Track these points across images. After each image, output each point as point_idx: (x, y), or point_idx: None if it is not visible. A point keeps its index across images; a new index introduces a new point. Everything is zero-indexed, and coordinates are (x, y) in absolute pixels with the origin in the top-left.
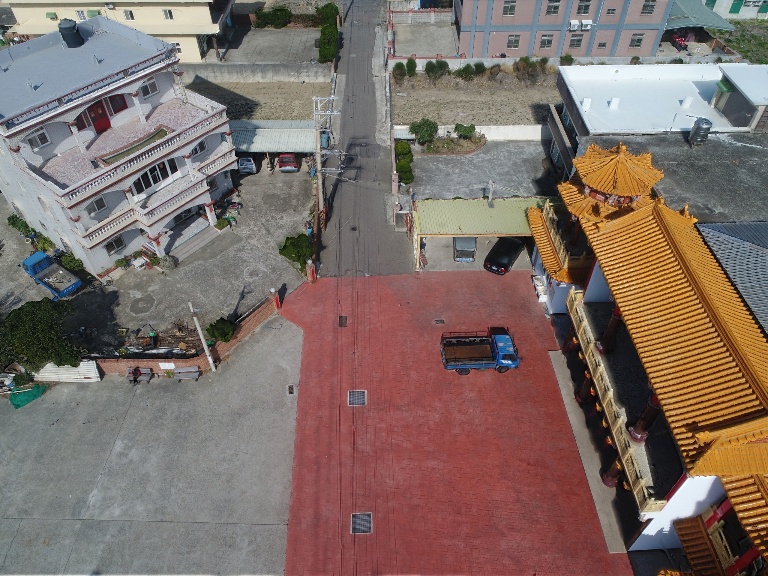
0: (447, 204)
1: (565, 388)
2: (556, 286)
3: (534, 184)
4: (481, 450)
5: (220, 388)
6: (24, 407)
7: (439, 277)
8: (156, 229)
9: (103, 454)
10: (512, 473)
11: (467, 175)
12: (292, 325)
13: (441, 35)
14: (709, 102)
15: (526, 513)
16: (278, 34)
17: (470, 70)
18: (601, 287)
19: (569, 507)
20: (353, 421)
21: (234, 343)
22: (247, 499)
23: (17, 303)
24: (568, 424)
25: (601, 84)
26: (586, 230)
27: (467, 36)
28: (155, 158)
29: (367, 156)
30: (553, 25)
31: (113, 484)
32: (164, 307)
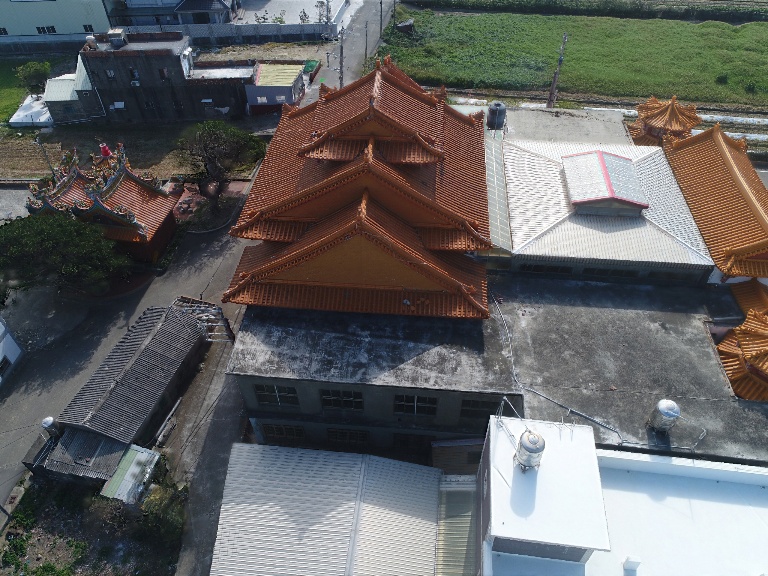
0: None
1: None
2: None
3: None
4: None
5: None
6: None
7: None
8: None
9: None
10: None
11: None
12: None
13: None
14: (582, 575)
15: None
16: None
17: None
18: None
19: None
20: None
21: None
22: None
23: None
24: None
25: None
26: None
27: None
28: None
29: None
30: None
31: None
32: None
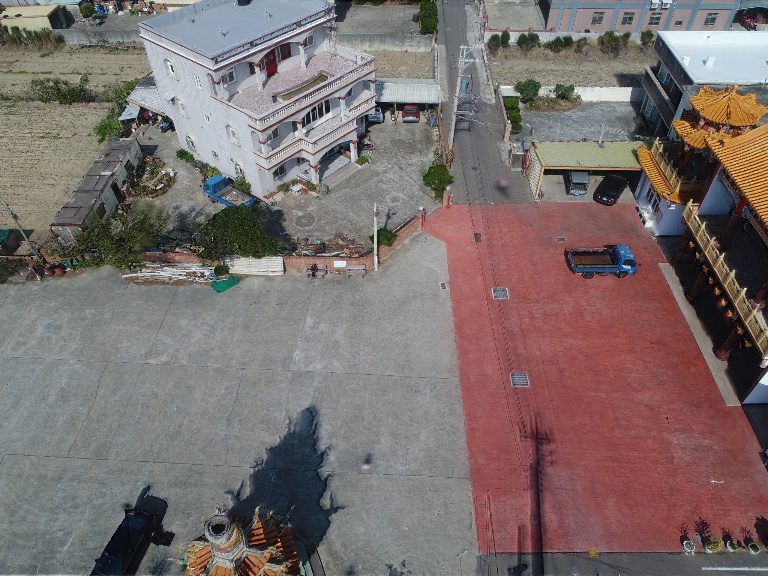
0: (563, 145)
1: (676, 290)
2: (666, 209)
3: (629, 136)
4: (611, 332)
5: (384, 283)
6: (225, 292)
7: (555, 206)
8: (317, 158)
9: (298, 326)
10: (639, 349)
11: (568, 128)
12: (435, 239)
13: (527, 13)
14: None
15: (654, 376)
16: (377, 10)
17: (559, 42)
18: (716, 199)
19: (689, 373)
20: (500, 309)
21: (390, 250)
22: (423, 361)
23: (200, 216)
24: (682, 316)
25: (695, 47)
26: (712, 146)
27: (556, 12)
28: (322, 96)
29: (476, 111)
30: (635, 4)
31: (311, 347)
32: (324, 223)
